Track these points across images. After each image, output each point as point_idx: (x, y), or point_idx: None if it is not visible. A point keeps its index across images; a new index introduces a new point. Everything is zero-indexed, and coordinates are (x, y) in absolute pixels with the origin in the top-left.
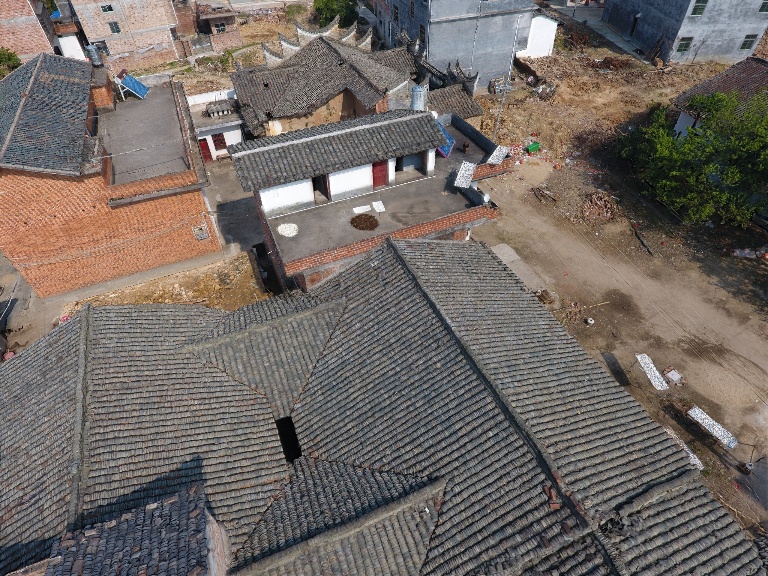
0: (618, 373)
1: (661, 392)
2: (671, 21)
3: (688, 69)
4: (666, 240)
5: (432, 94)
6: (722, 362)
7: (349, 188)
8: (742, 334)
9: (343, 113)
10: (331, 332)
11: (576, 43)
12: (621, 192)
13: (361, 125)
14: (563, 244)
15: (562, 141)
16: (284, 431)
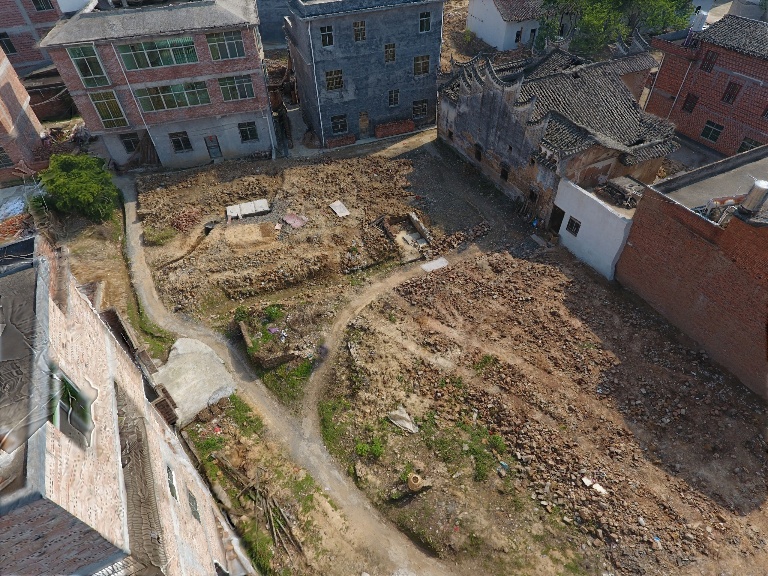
0: None
1: None
2: None
3: None
4: None
5: None
6: None
7: None
8: None
9: None
10: None
11: None
12: None
13: None
14: None
15: None
16: None
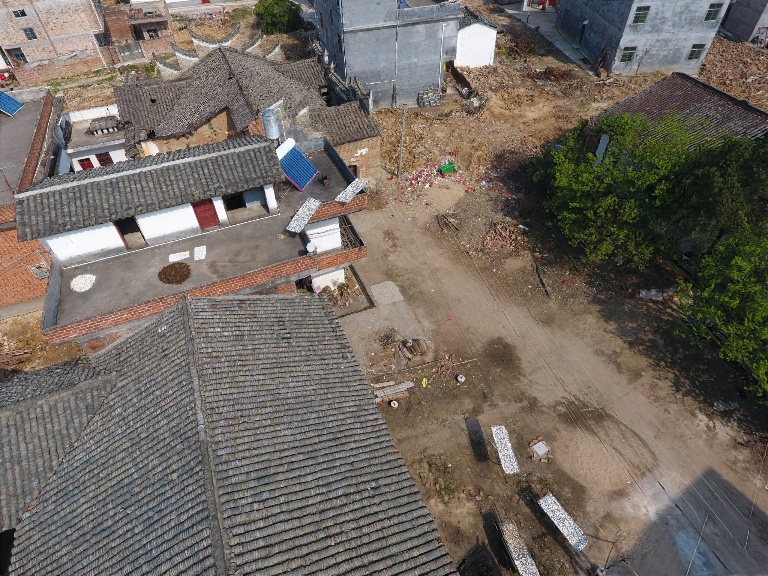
0: (478, 445)
1: (521, 470)
2: (614, 29)
3: (631, 81)
4: (568, 278)
5: (324, 112)
6: (599, 431)
7: (168, 231)
8: (629, 395)
9: (230, 132)
10: (90, 417)
11: (521, 51)
12: (532, 220)
13: (187, 157)
14: (454, 282)
15: (480, 161)
16: None
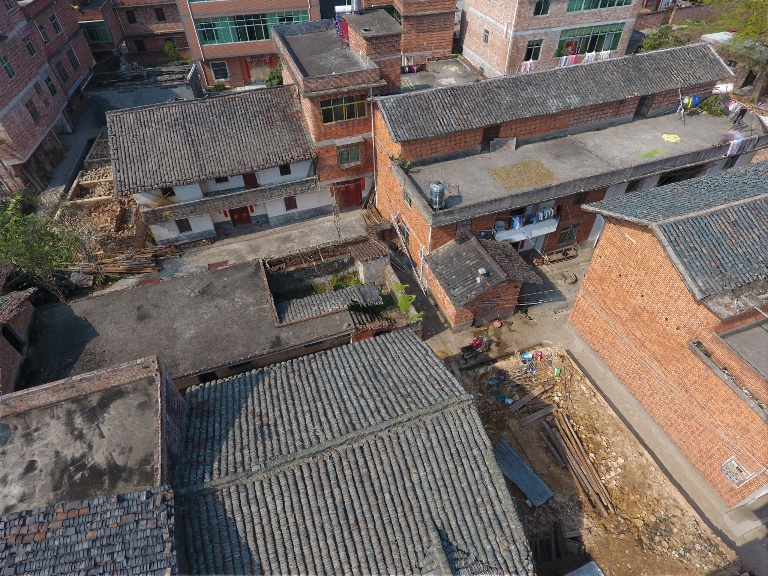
0: None
1: None
2: None
3: None
4: None
5: None
6: None
7: None
8: None
9: None
10: None
11: None
12: None
13: None
14: None
15: None
16: None
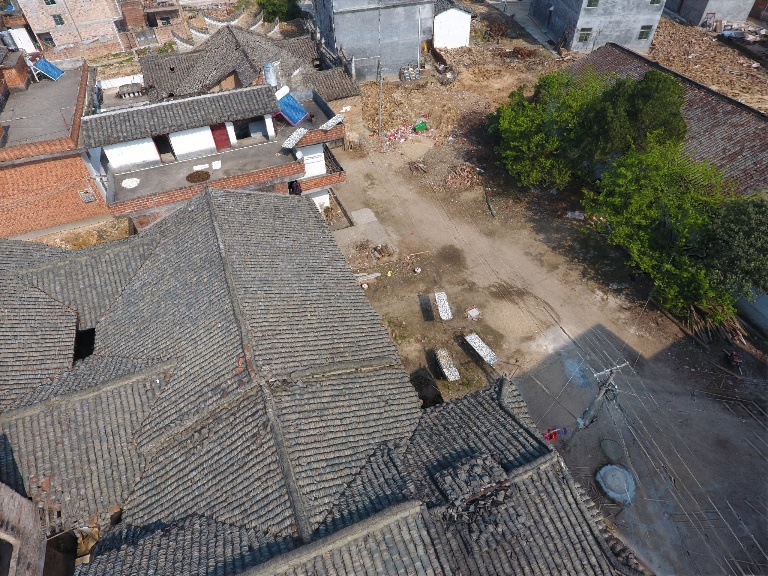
0: (427, 311)
1: (457, 325)
2: (573, 13)
3: None
4: (511, 205)
5: (315, 76)
6: (519, 302)
7: (192, 149)
8: (546, 280)
9: None
10: (143, 262)
11: (494, 35)
12: (487, 165)
13: None
14: (419, 208)
15: (449, 121)
16: (83, 336)
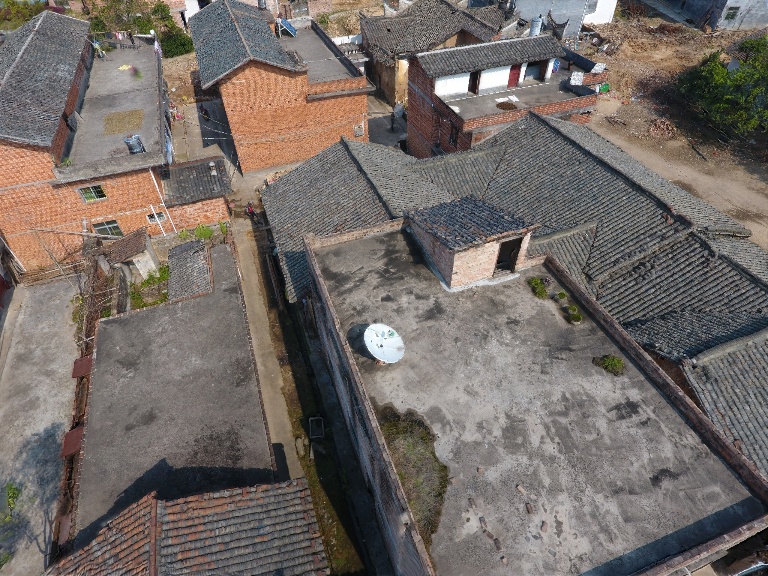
0: None
1: None
2: None
3: (734, 34)
4: (717, 152)
5: None
6: (762, 222)
7: (491, 85)
8: None
9: None
10: (497, 166)
11: (633, 13)
12: (679, 120)
13: None
14: (635, 153)
15: (628, 84)
16: None
